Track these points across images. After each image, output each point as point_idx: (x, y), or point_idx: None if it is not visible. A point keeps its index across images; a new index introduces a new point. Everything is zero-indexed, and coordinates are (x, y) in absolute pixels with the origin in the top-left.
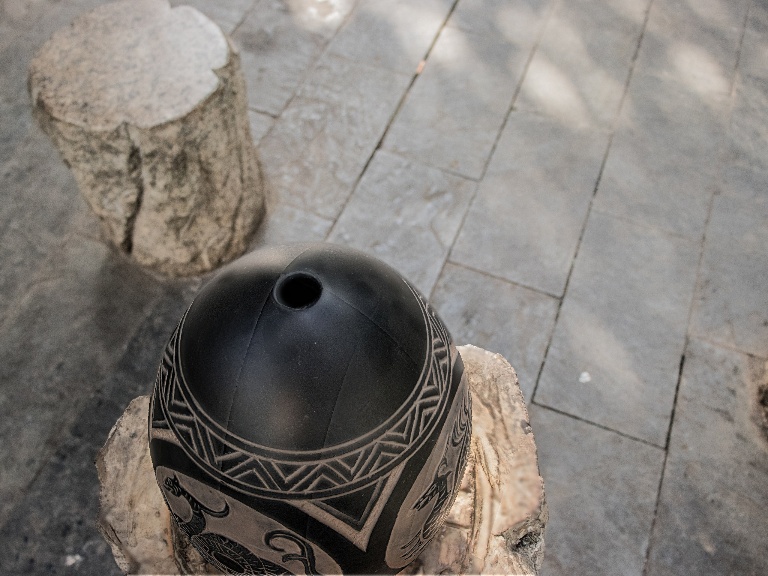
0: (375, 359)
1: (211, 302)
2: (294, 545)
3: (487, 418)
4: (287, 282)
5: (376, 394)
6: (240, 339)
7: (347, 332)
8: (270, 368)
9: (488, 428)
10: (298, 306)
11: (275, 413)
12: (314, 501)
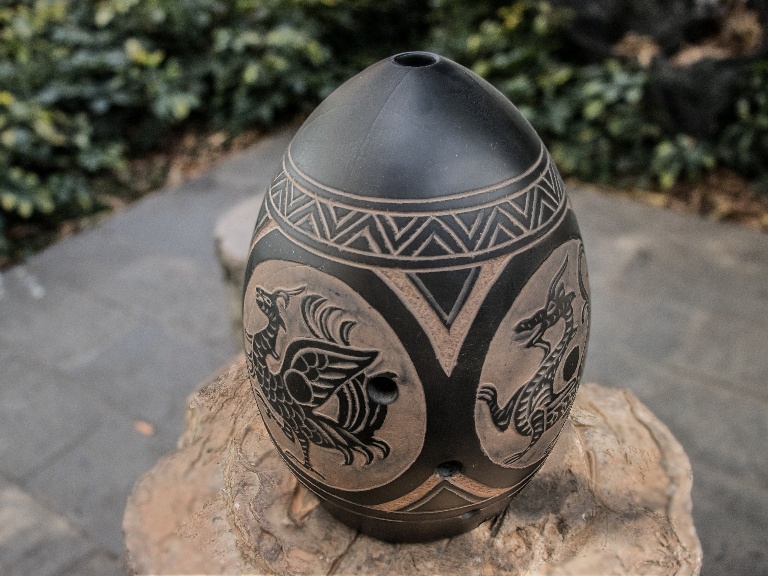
0: (345, 125)
1: None
2: None
3: None
4: (429, 60)
5: None
6: None
7: (368, 92)
8: None
9: None
10: None
11: None
12: None
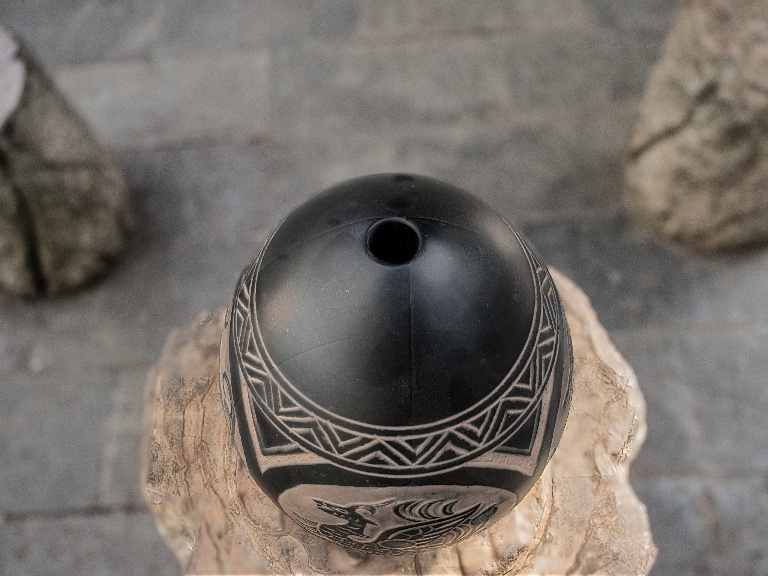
0: (375, 363)
1: (364, 181)
2: (230, 402)
3: (562, 567)
4: (400, 227)
5: (346, 386)
6: (324, 224)
7: (378, 315)
8: (307, 267)
9: (551, 573)
10: (377, 252)
11: (278, 300)
12: (249, 392)
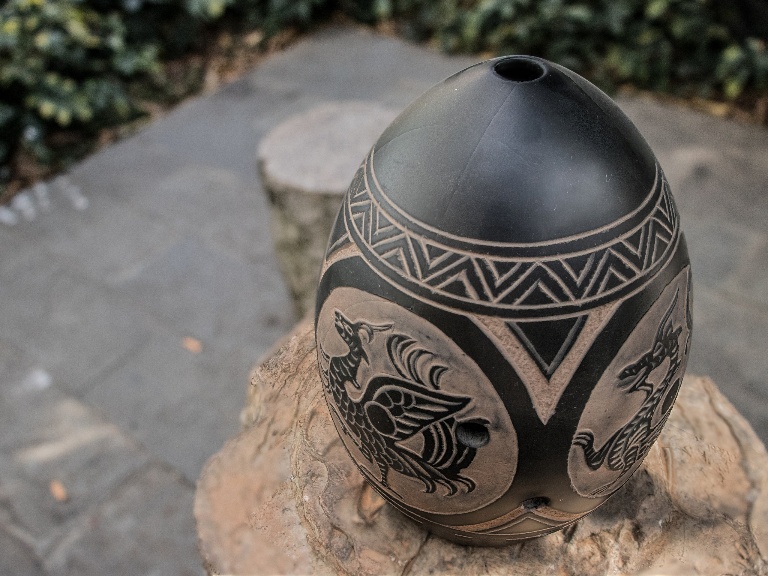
0: (440, 151)
1: None
2: None
3: None
4: (534, 68)
5: (408, 168)
6: None
7: (466, 111)
8: None
9: None
10: None
11: None
12: None
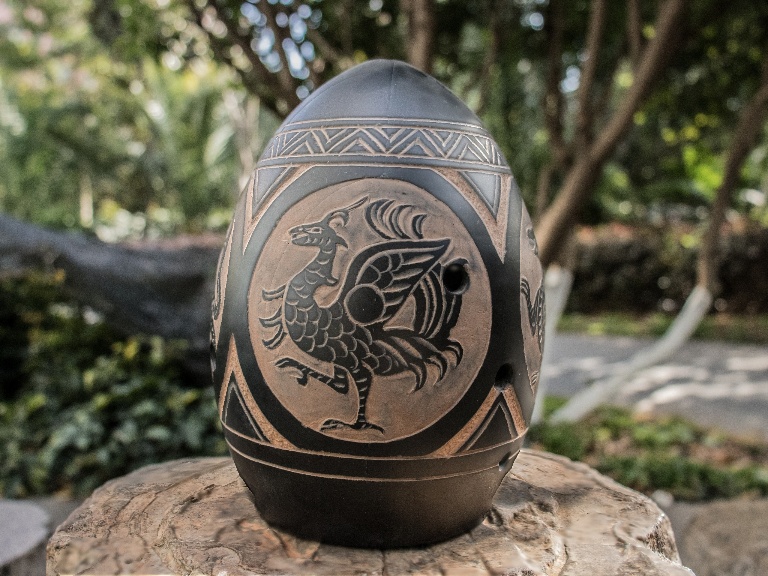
0: (365, 83)
1: None
2: None
3: None
4: None
5: None
6: None
7: None
8: None
9: None
10: None
11: None
12: None
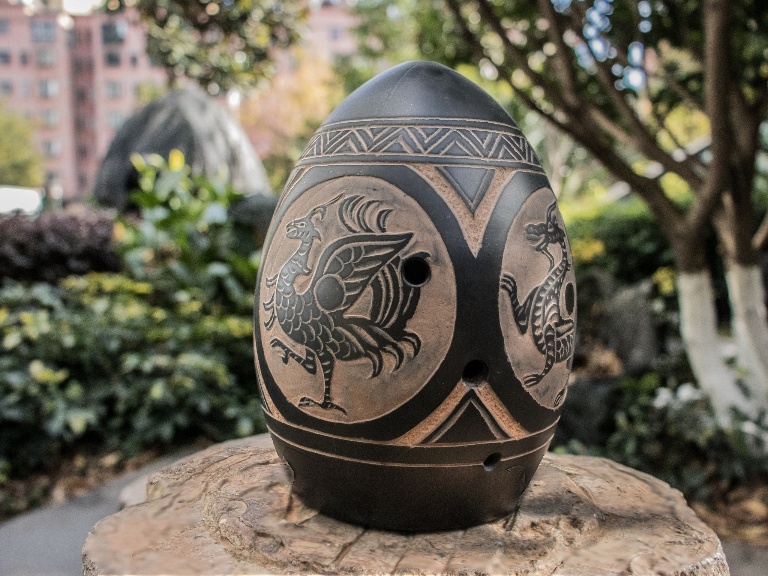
0: None
1: None
2: None
3: None
4: None
5: None
6: None
7: (390, 71)
8: None
9: None
10: None
11: None
12: None
